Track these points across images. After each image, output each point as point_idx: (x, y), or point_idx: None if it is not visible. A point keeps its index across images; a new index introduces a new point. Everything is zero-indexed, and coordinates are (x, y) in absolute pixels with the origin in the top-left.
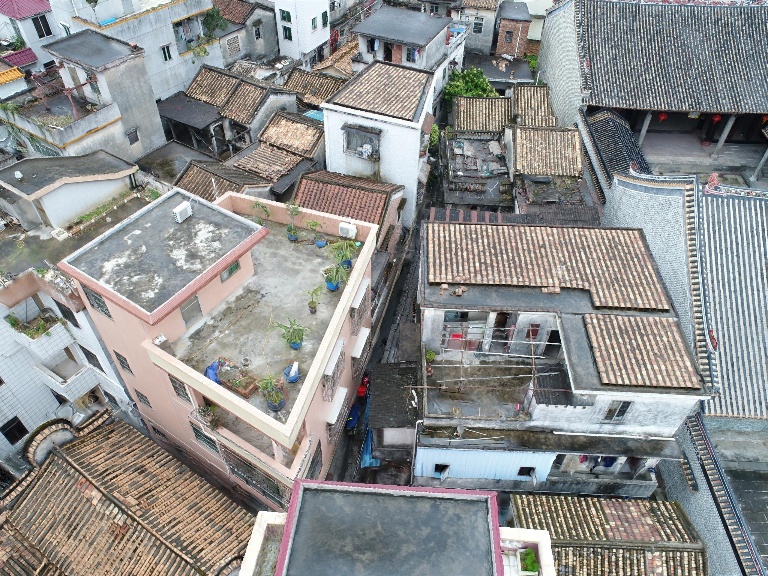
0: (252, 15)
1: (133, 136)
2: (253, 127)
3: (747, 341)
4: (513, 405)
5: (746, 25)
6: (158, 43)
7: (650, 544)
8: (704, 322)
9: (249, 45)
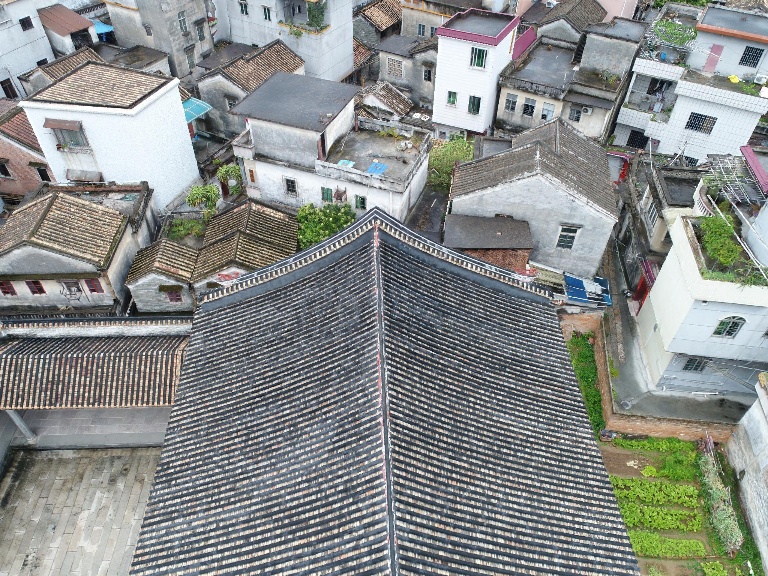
0: (426, 53)
1: (150, 30)
2: (201, 87)
3: None
4: None
5: (344, 573)
6: (262, 1)
7: None
8: None
9: (414, 79)
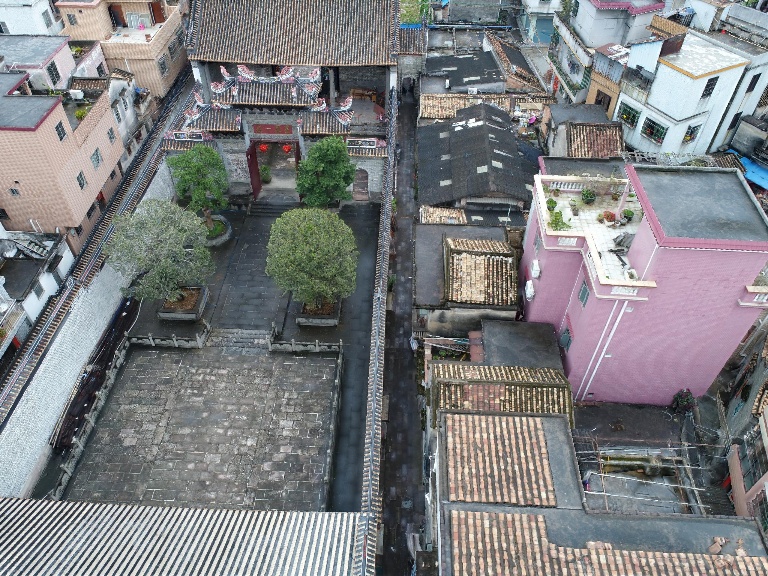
0: None
1: None
2: None
3: (305, 572)
4: (593, 491)
5: None
6: None
7: (475, 381)
8: (366, 575)
9: None
